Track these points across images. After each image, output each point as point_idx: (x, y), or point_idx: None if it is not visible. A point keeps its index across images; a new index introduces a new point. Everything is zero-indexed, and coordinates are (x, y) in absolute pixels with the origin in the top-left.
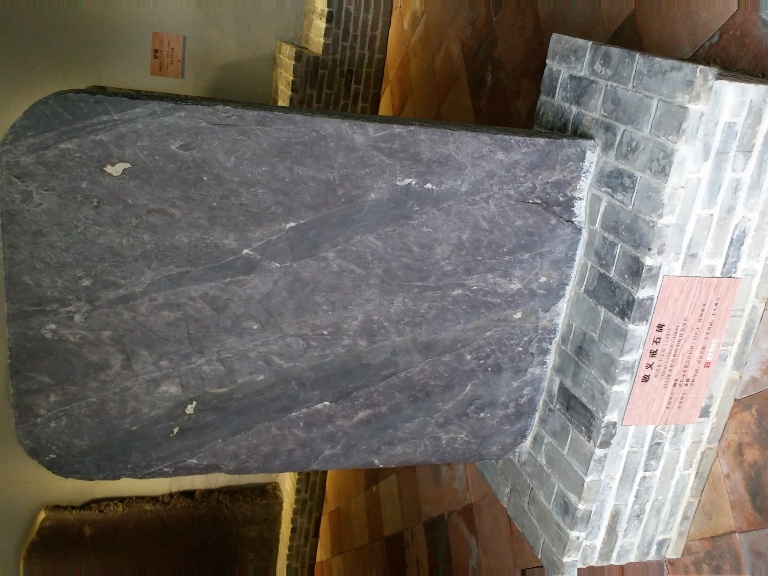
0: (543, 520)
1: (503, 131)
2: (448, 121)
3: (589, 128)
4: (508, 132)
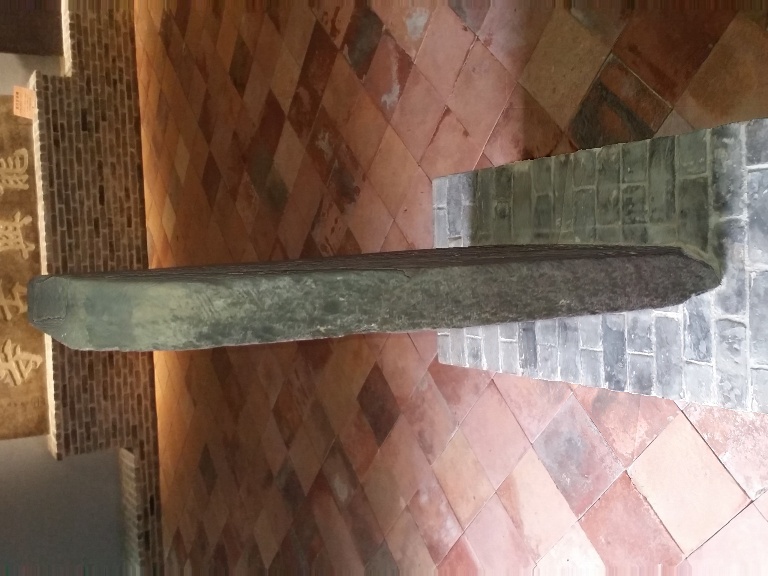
0: (456, 330)
1: (644, 291)
2: (604, 261)
3: (732, 259)
4: (648, 290)
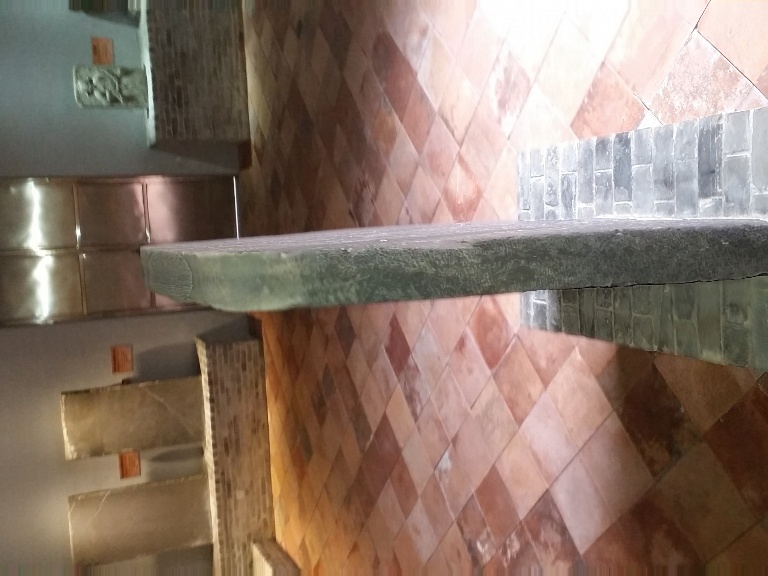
0: None
1: None
2: None
3: None
4: None
